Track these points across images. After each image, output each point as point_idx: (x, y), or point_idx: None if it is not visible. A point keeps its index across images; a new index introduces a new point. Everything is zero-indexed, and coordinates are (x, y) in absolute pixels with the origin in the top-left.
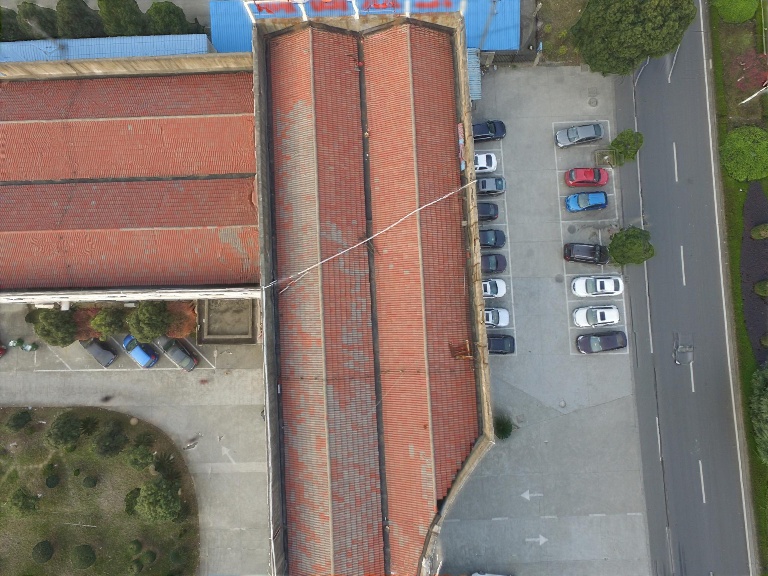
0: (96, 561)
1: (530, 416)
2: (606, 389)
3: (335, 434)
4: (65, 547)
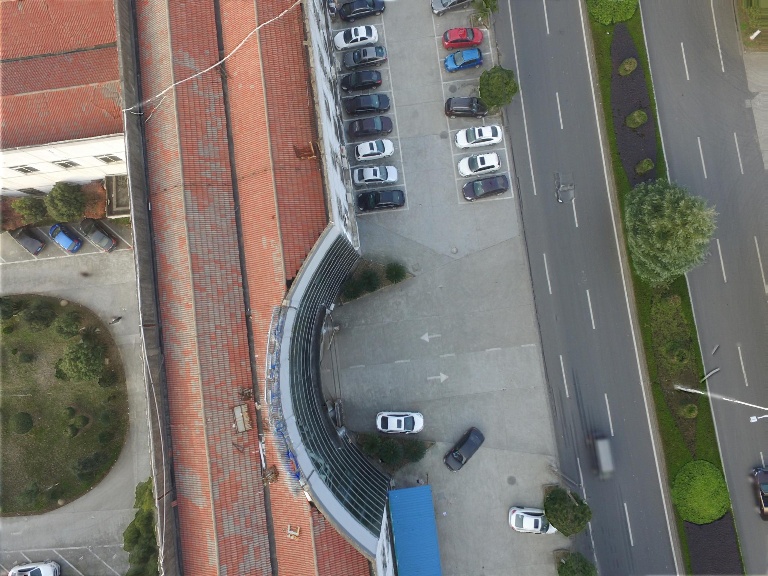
0: (36, 431)
1: (424, 264)
2: (494, 232)
3: (195, 233)
4: (8, 420)
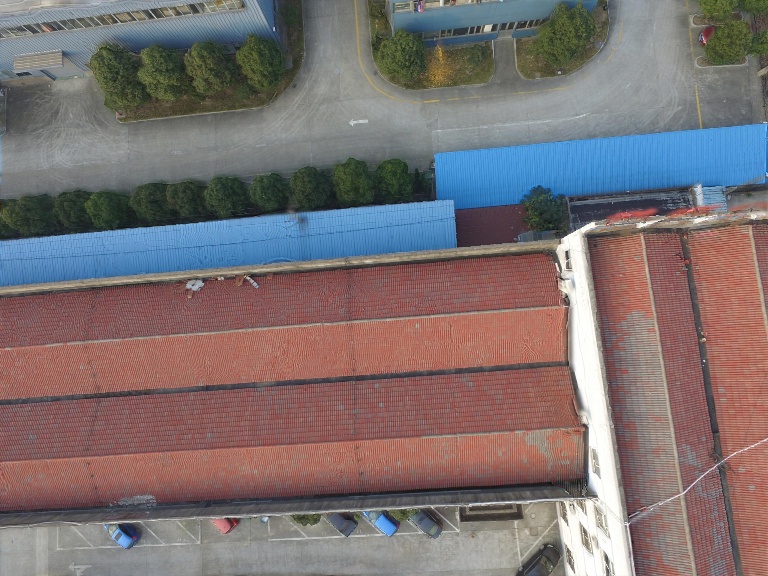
0: None
1: None
2: None
3: None
4: None
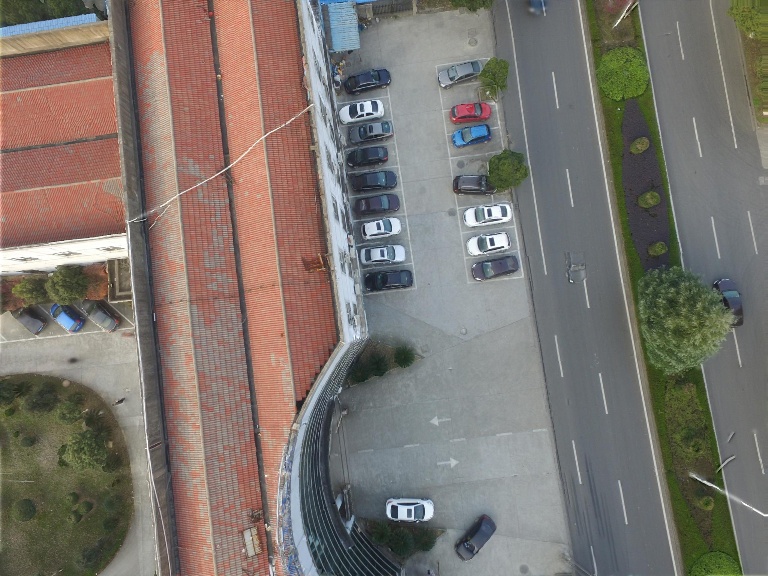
0: (39, 515)
1: (433, 345)
2: (504, 313)
3: (201, 350)
4: (11, 505)
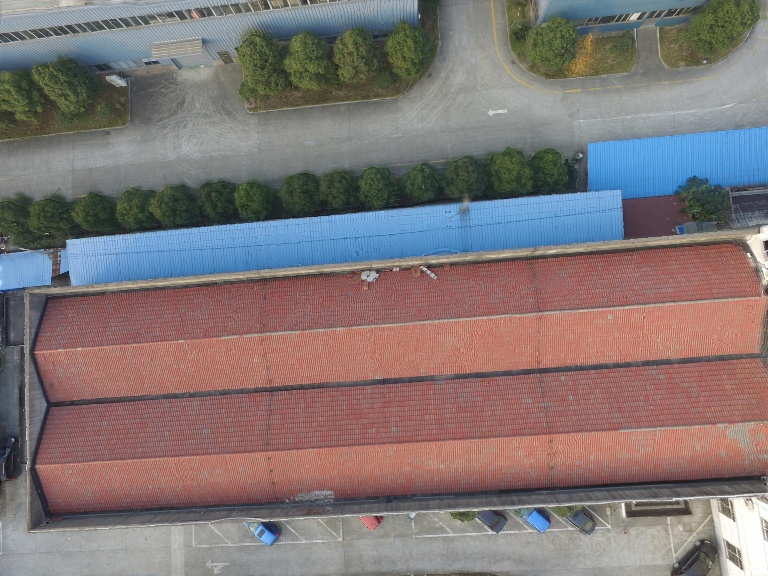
0: None
1: None
2: None
3: None
4: None
